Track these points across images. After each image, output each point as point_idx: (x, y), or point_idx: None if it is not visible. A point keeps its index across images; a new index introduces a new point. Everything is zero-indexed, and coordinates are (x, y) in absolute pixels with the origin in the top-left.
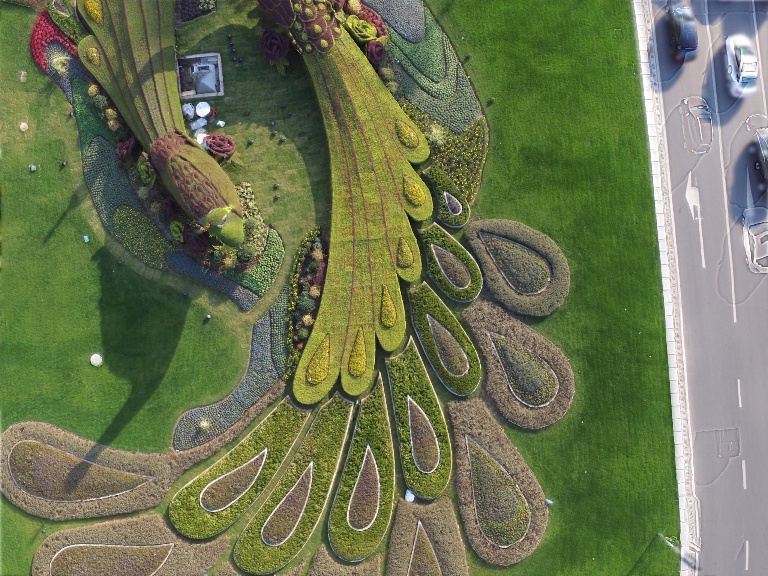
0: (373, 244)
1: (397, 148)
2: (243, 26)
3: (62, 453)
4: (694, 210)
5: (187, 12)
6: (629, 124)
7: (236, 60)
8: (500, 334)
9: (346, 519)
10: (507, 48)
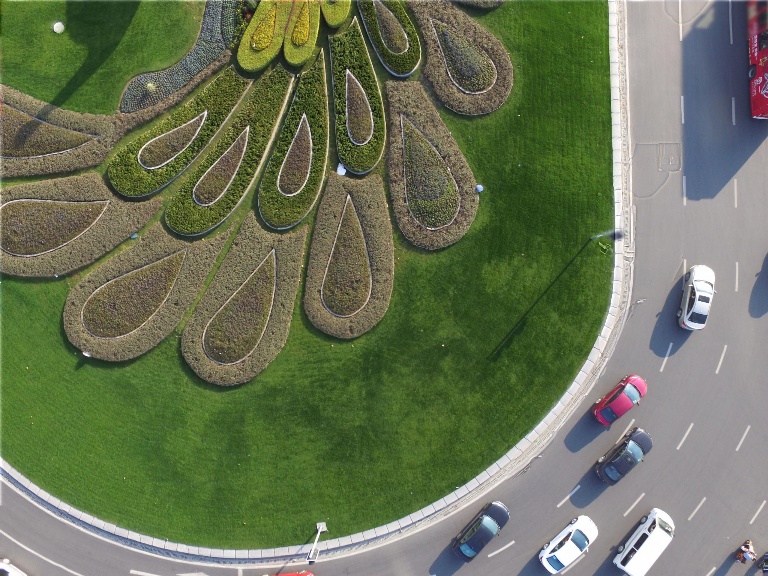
0: None
1: None
2: None
3: (16, 111)
4: None
5: None
6: None
7: None
8: (442, 21)
9: (276, 183)
10: None
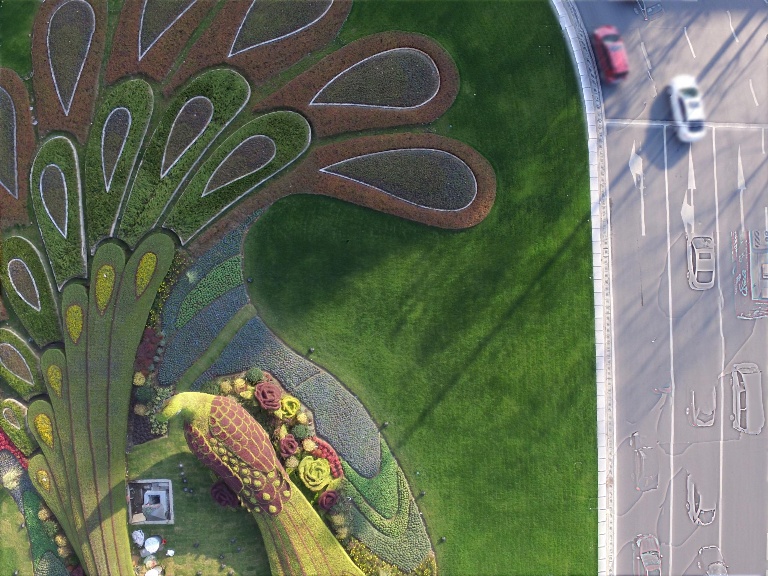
0: None
1: None
2: None
3: None
4: None
5: (139, 436)
6: (579, 560)
7: (187, 491)
8: None
9: None
10: (462, 485)
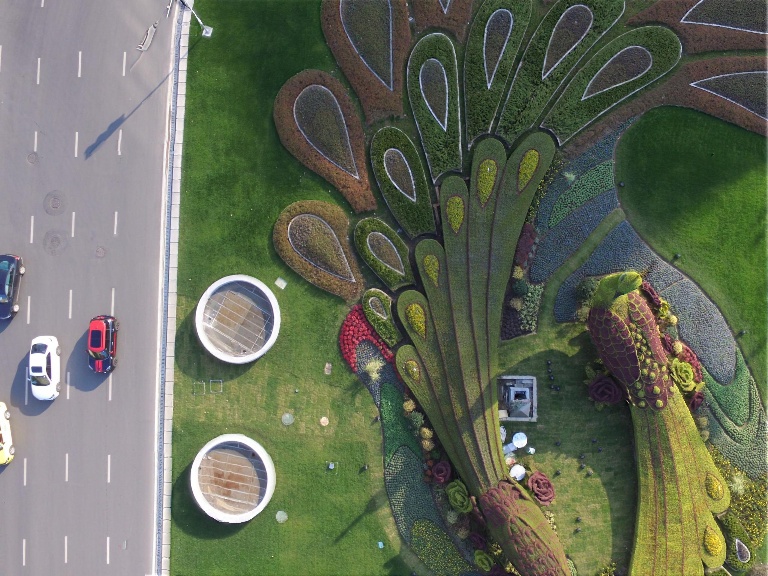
0: None
1: (704, 500)
2: (563, 353)
3: None
4: None
5: (508, 331)
6: None
7: (553, 388)
8: None
9: None
10: None
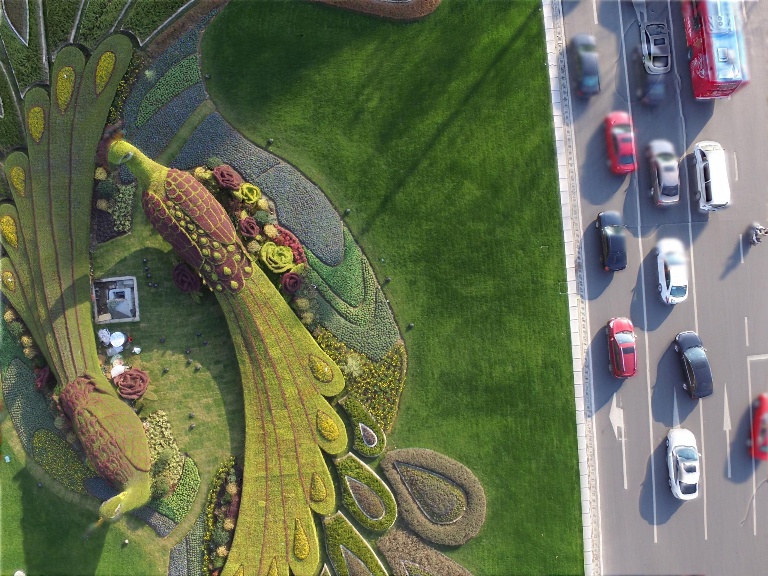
0: (286, 479)
1: (310, 383)
2: (158, 250)
3: None
4: (618, 431)
5: (102, 234)
6: (552, 347)
7: (151, 286)
8: (414, 562)
9: None
10: (428, 270)
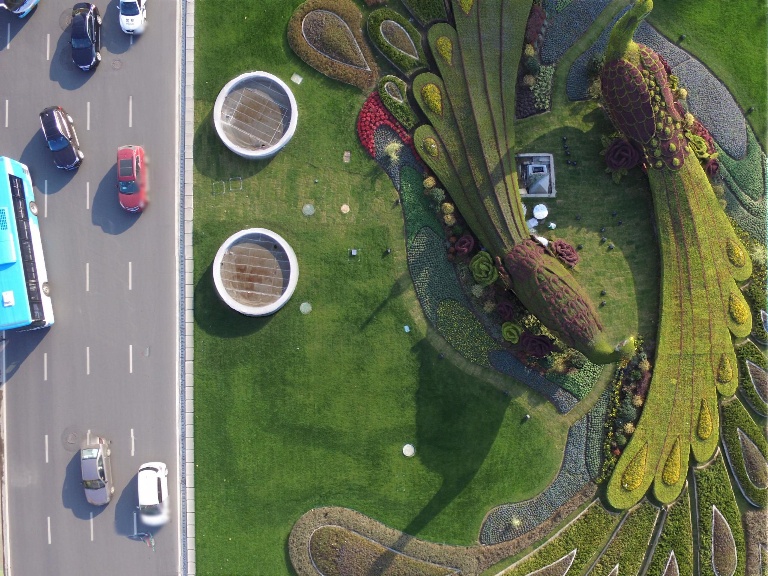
0: (697, 358)
1: (726, 266)
2: (578, 129)
3: (367, 540)
4: None
5: (522, 110)
6: None
7: (570, 163)
8: None
9: None
10: None
